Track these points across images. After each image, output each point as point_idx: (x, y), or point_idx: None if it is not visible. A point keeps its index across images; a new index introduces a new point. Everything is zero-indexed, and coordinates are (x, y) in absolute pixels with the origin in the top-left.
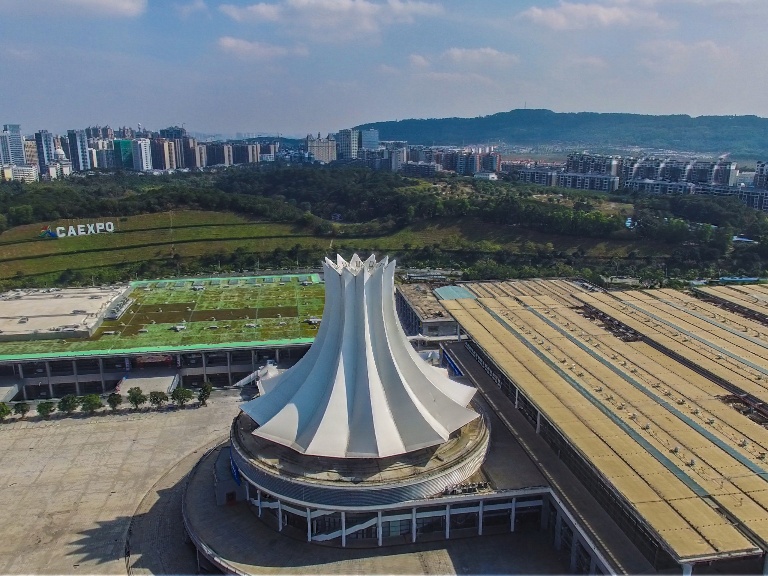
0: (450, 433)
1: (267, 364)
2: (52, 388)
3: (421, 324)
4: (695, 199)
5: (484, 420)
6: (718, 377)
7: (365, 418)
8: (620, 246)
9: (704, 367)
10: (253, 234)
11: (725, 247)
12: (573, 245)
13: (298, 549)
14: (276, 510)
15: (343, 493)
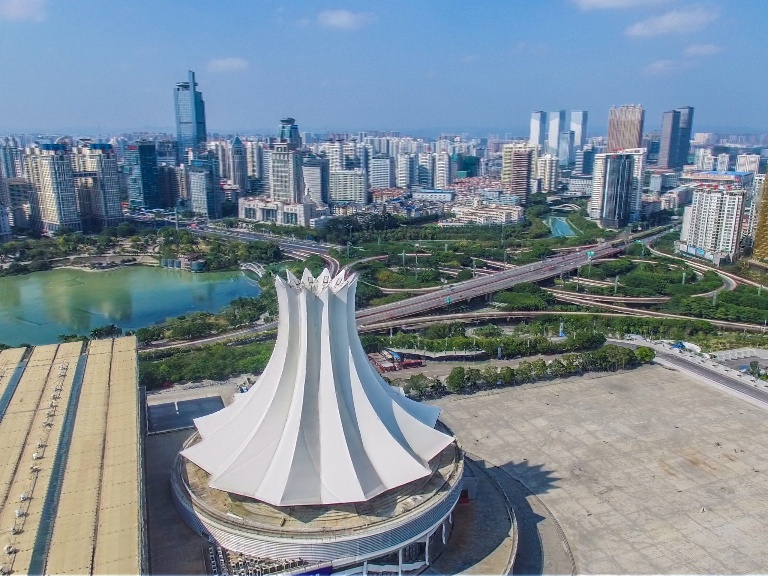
0: None
1: None
2: None
3: None
4: None
5: None
6: None
7: None
8: None
9: None
10: None
11: None
12: None
13: None
14: None
15: None
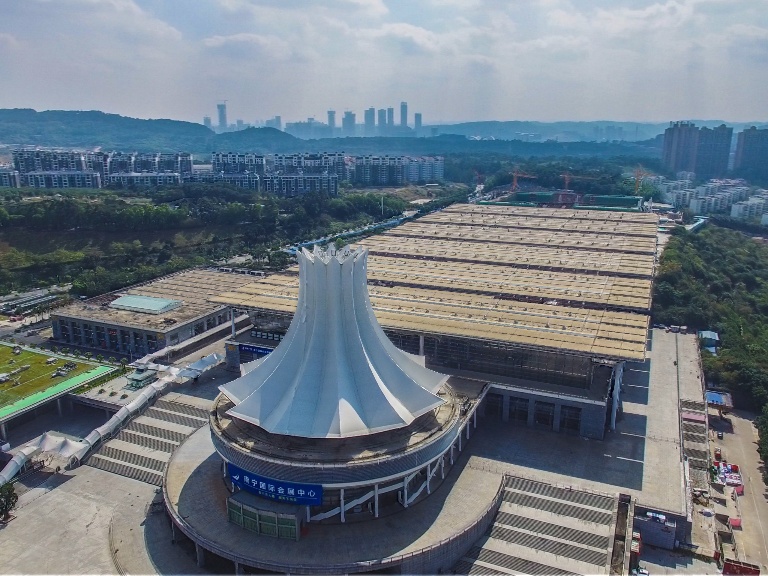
0: None
1: (45, 435)
2: None
3: (162, 335)
4: (206, 186)
5: None
6: (475, 290)
7: (404, 382)
8: (196, 233)
9: (459, 288)
10: None
11: (275, 221)
12: (153, 239)
13: (412, 515)
14: (370, 501)
15: (441, 442)
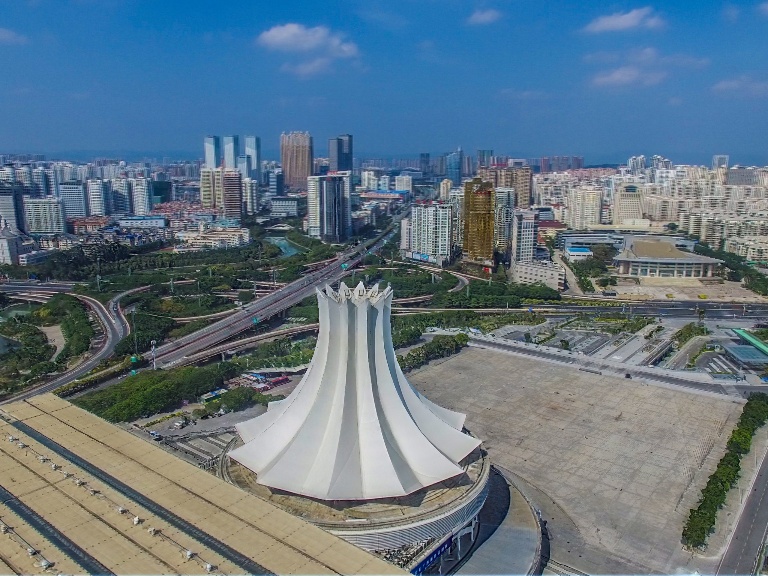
0: None
1: None
2: None
3: None
4: None
5: None
6: None
7: None
8: None
9: None
10: None
11: None
12: None
13: None
14: None
15: None
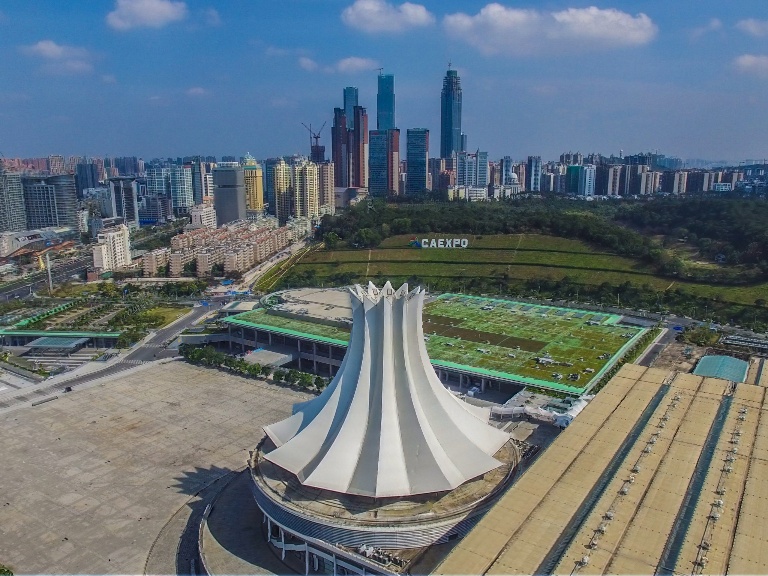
0: (411, 494)
1: None
2: (316, 364)
3: None
4: None
5: (483, 500)
6: None
7: (329, 444)
8: None
9: None
10: (591, 265)
11: None
12: None
13: (254, 543)
14: None
15: (271, 504)
